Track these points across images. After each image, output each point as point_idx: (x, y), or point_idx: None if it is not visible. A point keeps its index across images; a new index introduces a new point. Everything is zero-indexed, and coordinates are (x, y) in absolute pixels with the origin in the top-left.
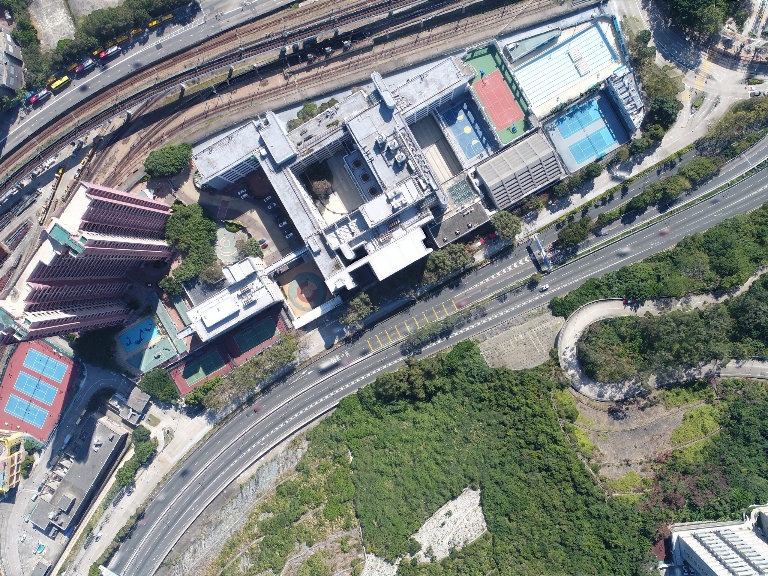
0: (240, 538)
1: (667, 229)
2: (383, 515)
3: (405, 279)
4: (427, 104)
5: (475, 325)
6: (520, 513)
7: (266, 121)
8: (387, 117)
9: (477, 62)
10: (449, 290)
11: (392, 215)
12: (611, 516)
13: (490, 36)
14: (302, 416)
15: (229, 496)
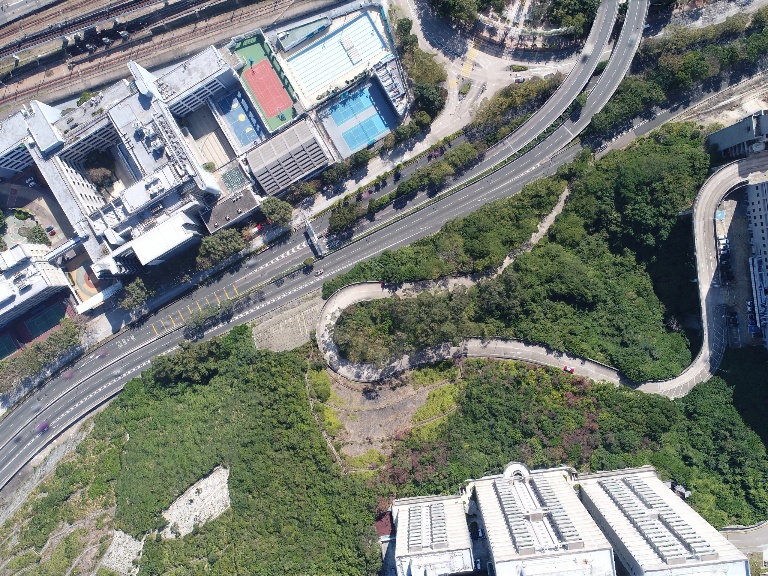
0: (15, 517)
1: (435, 214)
2: (136, 493)
3: (177, 264)
4: (190, 92)
5: (254, 309)
6: (262, 490)
7: (32, 110)
8: (146, 105)
9: (246, 51)
10: (230, 275)
11: (150, 201)
12: (342, 492)
13: (265, 26)
14: (92, 399)
15: (24, 478)
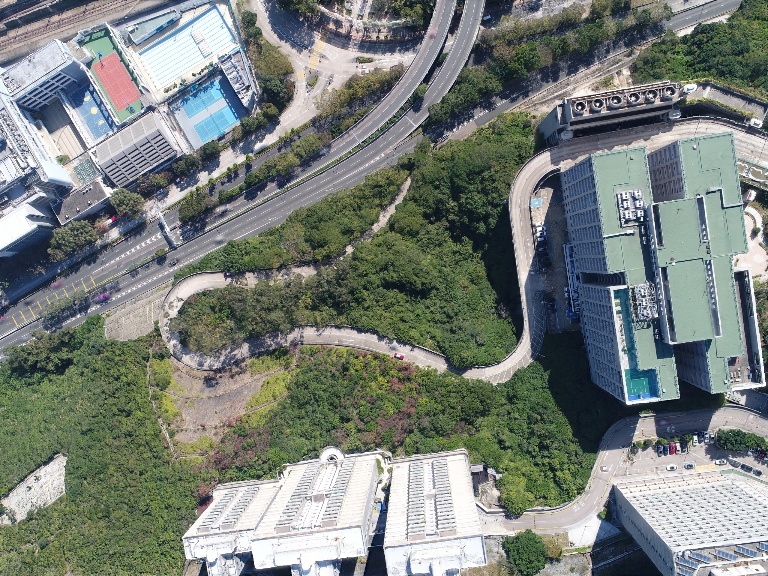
0: None
1: (283, 204)
2: None
3: (29, 255)
4: (35, 85)
5: (111, 300)
6: (96, 476)
7: None
8: None
9: (95, 44)
10: (87, 266)
11: None
12: (170, 477)
13: (116, 19)
14: None
15: None
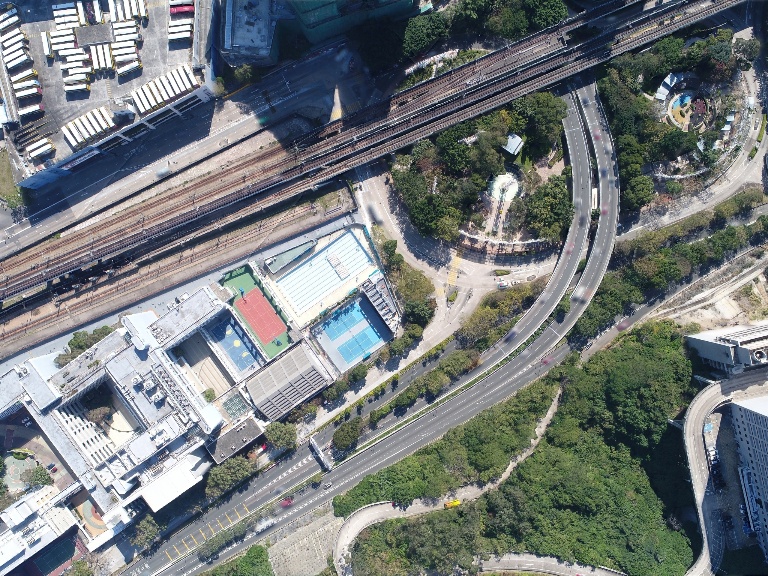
0: None
1: (435, 420)
2: None
3: (187, 498)
4: (185, 334)
5: (267, 526)
6: None
7: None
8: (143, 356)
9: (236, 281)
10: (239, 494)
11: (157, 451)
12: None
13: (251, 250)
14: None
15: None
